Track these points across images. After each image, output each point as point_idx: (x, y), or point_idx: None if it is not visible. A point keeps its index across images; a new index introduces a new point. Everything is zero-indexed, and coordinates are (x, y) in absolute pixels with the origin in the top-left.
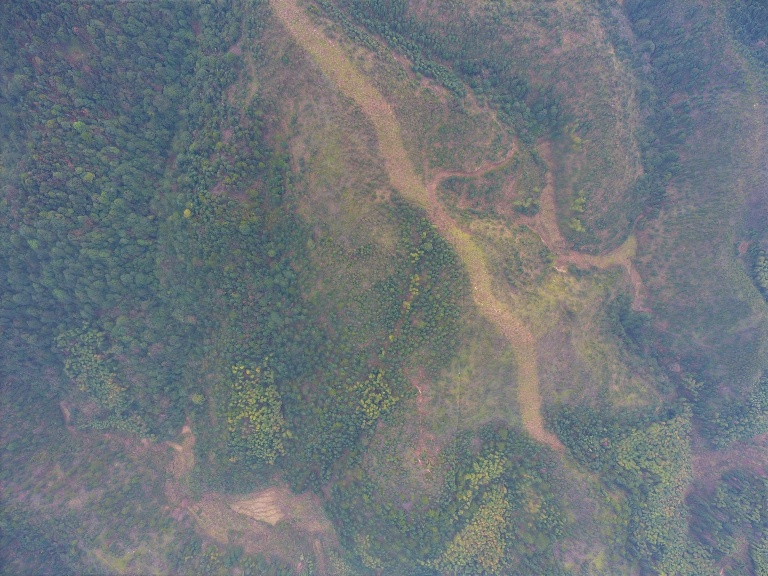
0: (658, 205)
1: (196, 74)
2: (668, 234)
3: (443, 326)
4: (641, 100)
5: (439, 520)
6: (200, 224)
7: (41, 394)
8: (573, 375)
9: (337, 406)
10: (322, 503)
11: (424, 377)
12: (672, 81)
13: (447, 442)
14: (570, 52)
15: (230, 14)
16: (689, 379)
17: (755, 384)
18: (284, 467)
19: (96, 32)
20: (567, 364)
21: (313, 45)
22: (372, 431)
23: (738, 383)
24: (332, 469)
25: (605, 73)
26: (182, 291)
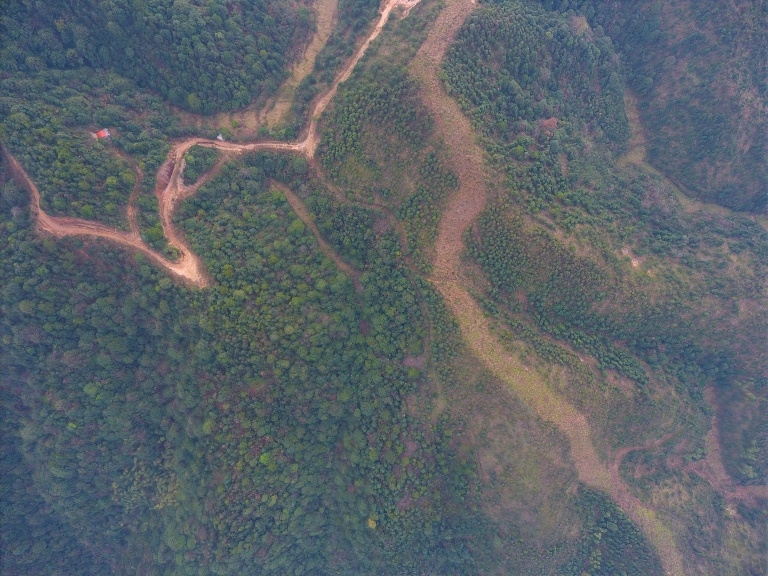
0: None
1: (368, 377)
2: None
3: None
4: None
5: None
6: (387, 536)
7: None
8: None
9: None
10: None
11: None
12: None
13: None
14: (748, 321)
15: (410, 330)
16: None
17: None
18: None
19: (282, 371)
20: None
21: (510, 375)
22: None
23: None
24: None
25: None
26: (353, 573)
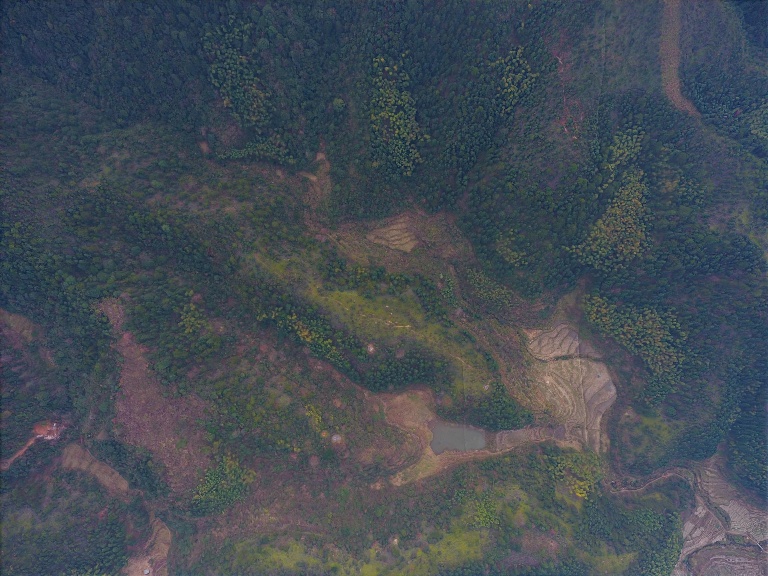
0: None
1: None
2: None
3: None
4: None
5: (587, 191)
6: None
7: (179, 127)
8: (710, 27)
9: (479, 88)
10: (457, 220)
11: (567, 39)
12: None
13: (591, 108)
14: None
15: None
16: None
17: None
18: (419, 183)
19: None
20: (705, 12)
21: None
22: (512, 116)
23: None
24: (468, 176)
25: None
26: None
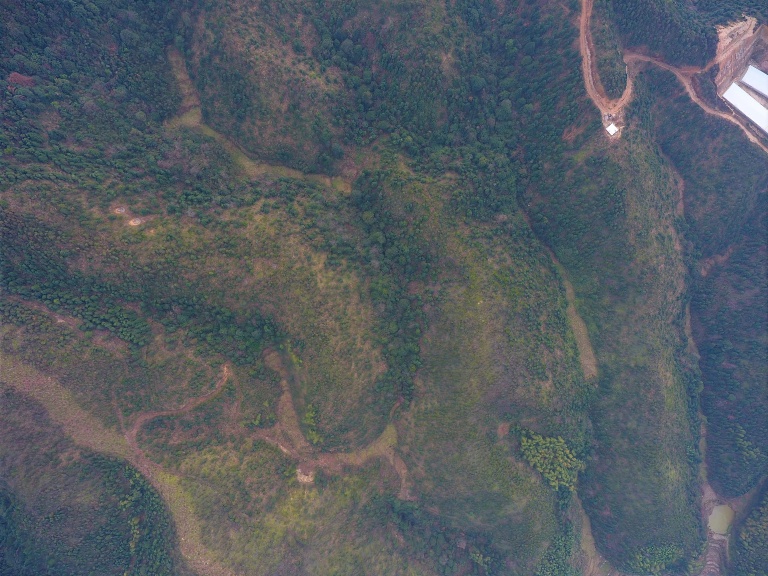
0: (408, 397)
1: None
2: (418, 429)
3: (162, 573)
4: (372, 298)
5: None
6: None
7: None
8: None
9: None
10: None
11: None
12: (406, 271)
13: None
14: (263, 280)
15: None
16: (476, 554)
17: (543, 555)
18: None
19: None
20: None
21: None
22: None
23: (522, 559)
24: None
25: (306, 296)
26: None
